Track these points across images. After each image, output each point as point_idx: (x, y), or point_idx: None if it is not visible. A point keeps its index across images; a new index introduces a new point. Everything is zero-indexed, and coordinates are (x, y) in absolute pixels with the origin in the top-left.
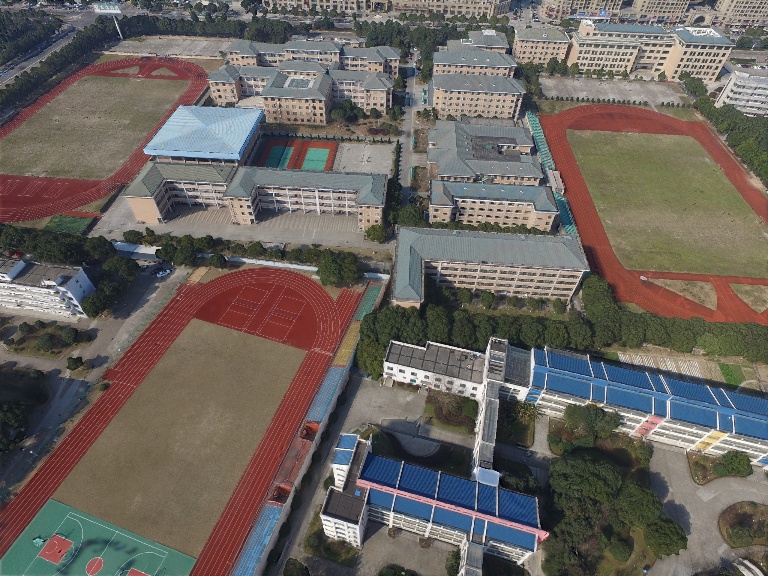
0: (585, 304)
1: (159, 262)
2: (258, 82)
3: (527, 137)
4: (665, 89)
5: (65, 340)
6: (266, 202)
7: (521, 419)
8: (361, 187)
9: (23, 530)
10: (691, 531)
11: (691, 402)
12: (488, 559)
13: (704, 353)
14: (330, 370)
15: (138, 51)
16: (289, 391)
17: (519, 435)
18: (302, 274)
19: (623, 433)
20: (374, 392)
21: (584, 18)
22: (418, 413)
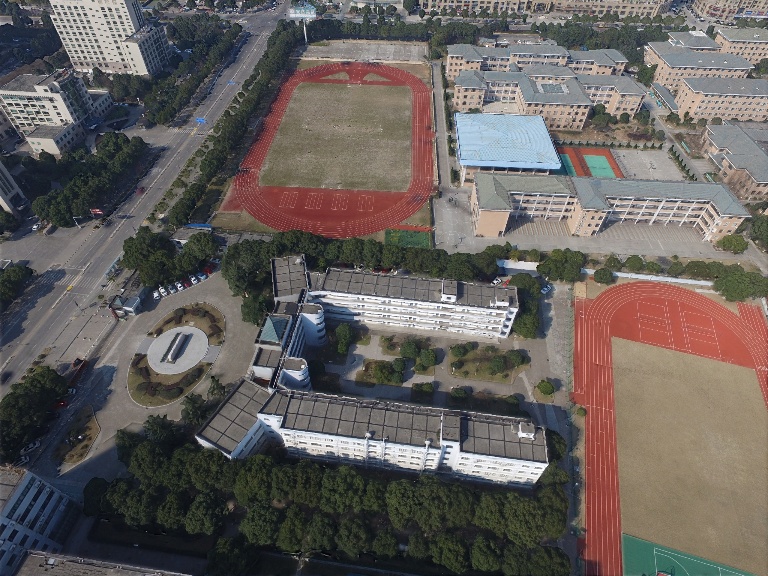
0: None
1: None
2: (502, 87)
3: None
4: None
5: (515, 363)
6: None
7: None
8: (713, 196)
9: (622, 568)
10: None
11: None
12: None
13: None
14: None
15: (332, 56)
16: None
17: None
18: (684, 288)
19: None
20: None
21: (750, 17)
22: None
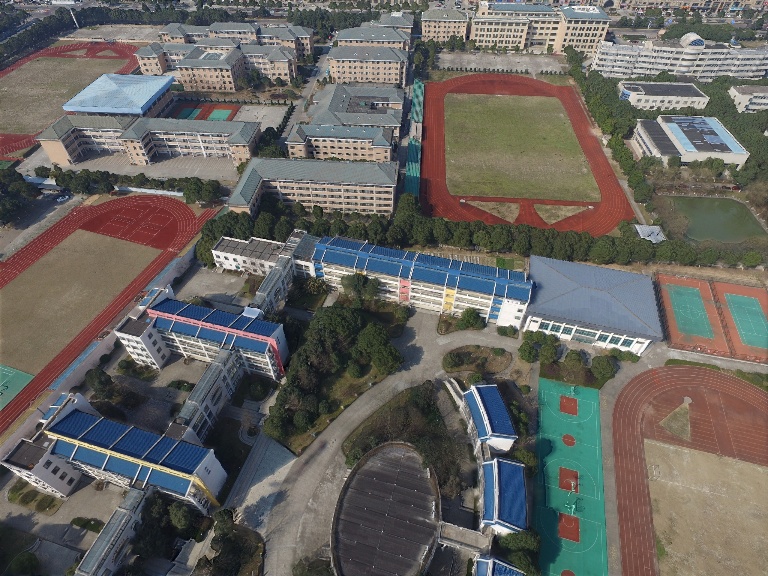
0: (396, 215)
1: (61, 191)
2: (180, 57)
3: (398, 96)
4: (551, 61)
5: None
6: (160, 147)
7: (310, 289)
8: (234, 131)
9: None
10: (420, 362)
11: (428, 266)
12: (253, 376)
13: (488, 251)
14: (173, 260)
15: (90, 37)
16: (139, 276)
17: (311, 303)
18: (177, 199)
19: (394, 302)
20: (206, 276)
21: None
22: (236, 290)
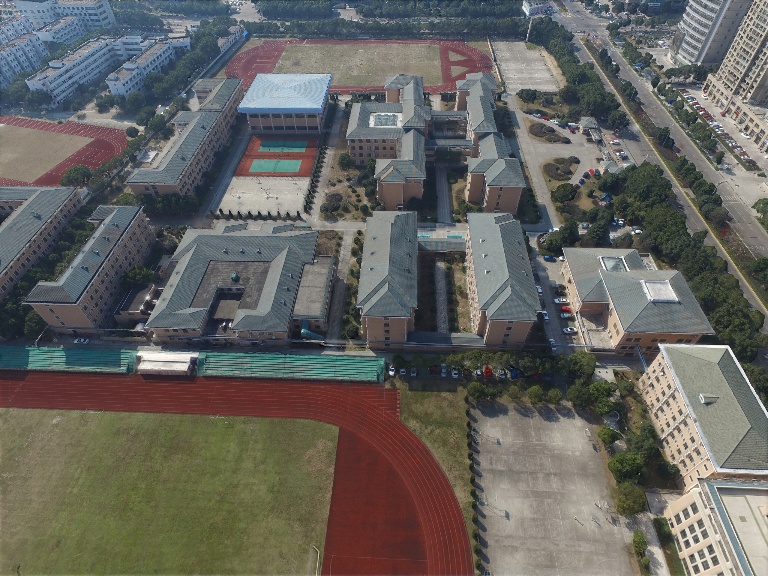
0: None
1: None
2: None
3: (246, 319)
4: None
5: None
6: None
7: None
8: None
9: None
10: None
11: None
12: None
13: None
14: None
15: (502, 52)
16: (5, 179)
17: None
18: None
19: None
20: None
21: None
22: None
